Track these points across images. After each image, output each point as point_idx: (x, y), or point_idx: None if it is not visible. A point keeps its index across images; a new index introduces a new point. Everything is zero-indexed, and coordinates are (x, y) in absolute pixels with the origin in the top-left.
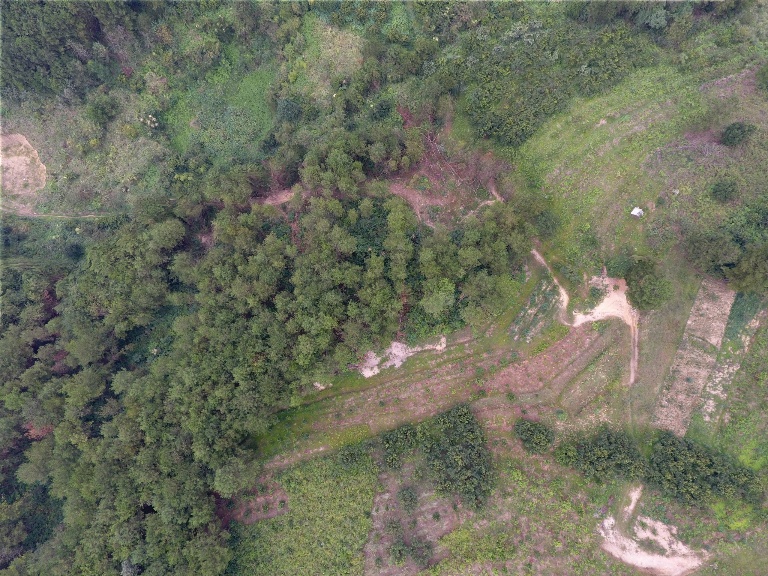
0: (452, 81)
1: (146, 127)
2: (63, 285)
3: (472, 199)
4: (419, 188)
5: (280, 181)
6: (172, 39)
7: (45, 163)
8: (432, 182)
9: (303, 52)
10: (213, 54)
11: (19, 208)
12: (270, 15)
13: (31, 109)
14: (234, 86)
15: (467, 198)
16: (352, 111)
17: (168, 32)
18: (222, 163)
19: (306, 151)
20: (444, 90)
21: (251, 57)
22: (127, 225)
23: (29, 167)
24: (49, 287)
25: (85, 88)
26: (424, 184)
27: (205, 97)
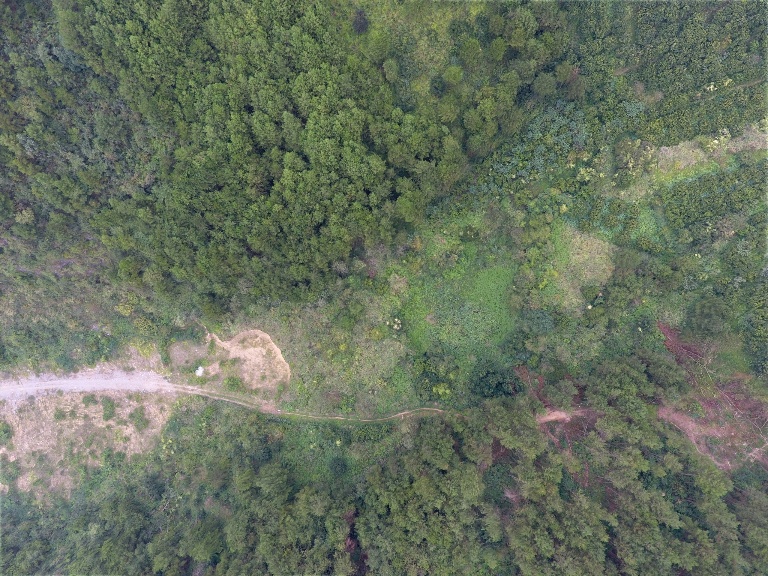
0: (727, 309)
1: (393, 331)
2: (367, 534)
3: (756, 435)
4: (692, 416)
5: (540, 397)
6: (422, 247)
7: (289, 362)
8: (705, 409)
9: (550, 257)
10: (457, 257)
11: (262, 404)
12: (519, 222)
13: (280, 313)
14: (470, 281)
15: (750, 434)
16: (612, 327)
17: (420, 242)
18: (467, 366)
19: (567, 368)
20: (726, 325)
21: (493, 258)
22: (387, 438)
23: (265, 359)
24: (351, 533)
25: (334, 294)
26: (698, 412)
27: (443, 294)
